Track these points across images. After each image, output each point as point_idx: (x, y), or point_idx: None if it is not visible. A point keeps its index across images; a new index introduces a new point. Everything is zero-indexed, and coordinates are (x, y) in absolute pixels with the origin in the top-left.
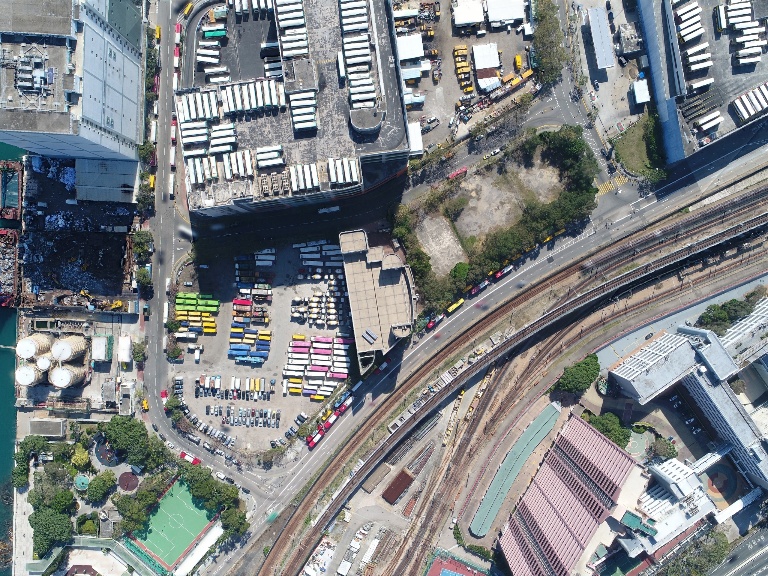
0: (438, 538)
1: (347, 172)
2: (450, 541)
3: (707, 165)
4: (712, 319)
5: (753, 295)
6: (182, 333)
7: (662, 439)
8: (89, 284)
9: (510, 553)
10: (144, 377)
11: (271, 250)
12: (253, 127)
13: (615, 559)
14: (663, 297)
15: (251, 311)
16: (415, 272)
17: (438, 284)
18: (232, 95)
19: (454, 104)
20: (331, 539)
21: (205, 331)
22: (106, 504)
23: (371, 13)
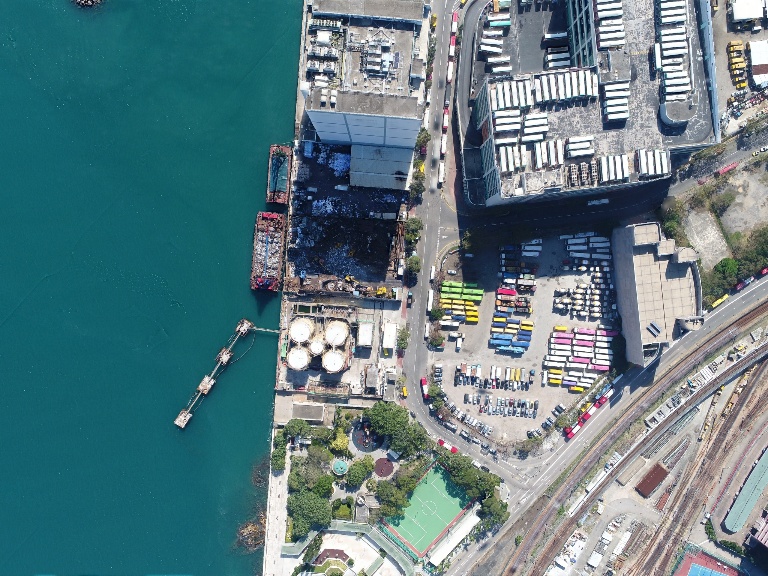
0: (689, 532)
1: (658, 164)
2: (701, 536)
3: None
4: None
5: None
6: (446, 321)
7: None
8: (353, 270)
9: None
10: (403, 364)
11: (539, 241)
12: (562, 117)
13: None
14: None
15: (514, 301)
16: None
17: (706, 279)
18: (547, 84)
19: (726, 99)
20: (583, 530)
21: (468, 320)
22: (360, 489)
23: (686, 6)
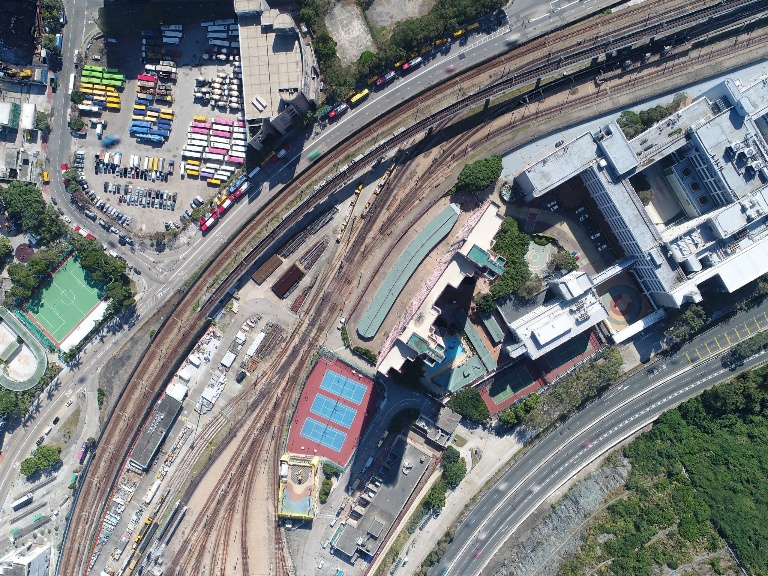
0: (325, 338)
1: None
2: (337, 342)
3: None
4: (625, 124)
5: (672, 103)
6: (86, 105)
7: (564, 251)
8: (2, 52)
9: None
10: (47, 150)
11: (178, 26)
12: None
13: (506, 376)
14: (577, 103)
15: (155, 89)
16: (320, 57)
17: (342, 70)
18: None
19: None
20: (218, 329)
21: (109, 106)
22: (2, 274)
23: None
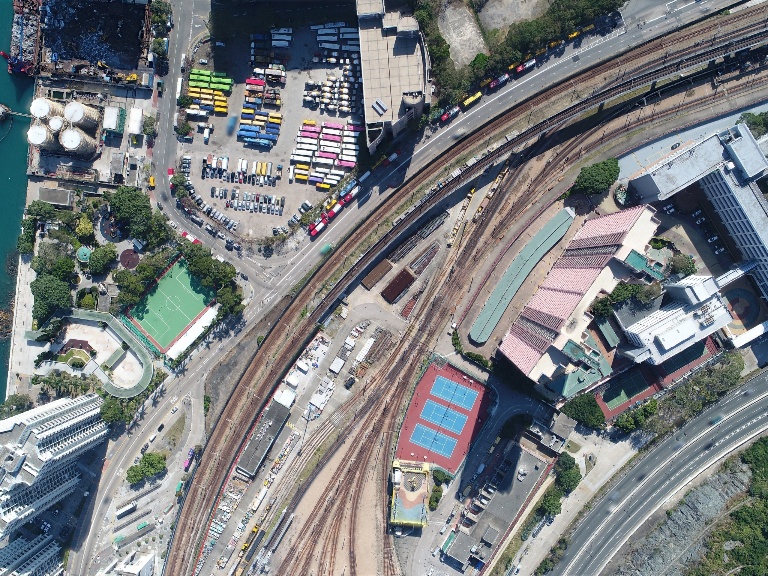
0: (435, 343)
1: None
2: (448, 347)
3: None
4: None
5: None
6: (193, 110)
7: (681, 255)
8: (107, 57)
9: (508, 347)
10: (153, 154)
11: (288, 30)
12: None
13: (620, 381)
14: (694, 105)
15: (263, 93)
16: (433, 60)
17: (456, 73)
18: None
19: None
20: (326, 334)
21: (216, 110)
22: (106, 280)
23: None
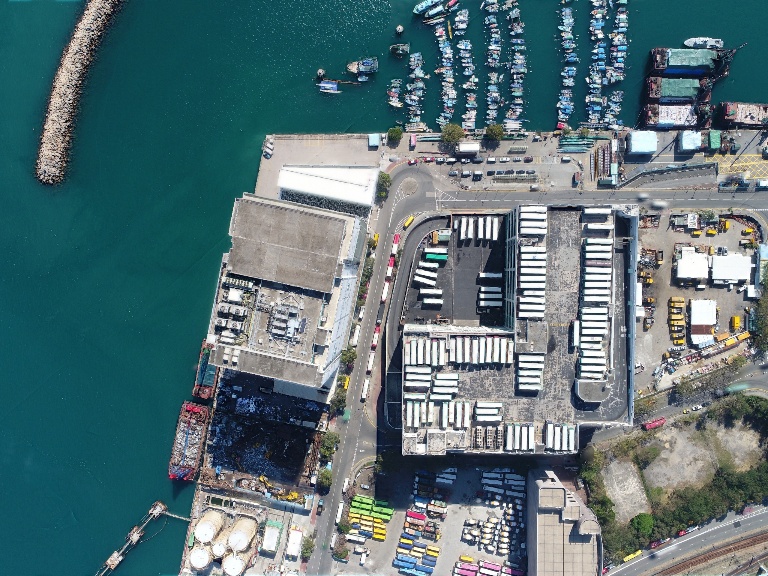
0: None
1: (565, 440)
2: None
3: None
4: None
5: None
6: (352, 536)
7: None
8: (268, 470)
9: None
10: (307, 569)
11: (454, 470)
12: (475, 377)
13: None
14: None
15: (423, 524)
16: None
17: (619, 534)
18: (461, 347)
19: (661, 353)
20: None
21: (375, 537)
22: None
23: (613, 285)
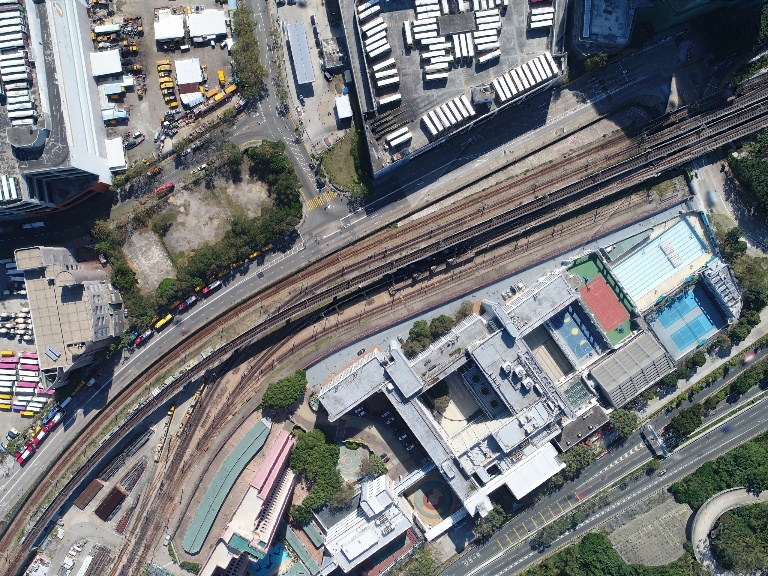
0: (153, 555)
1: (5, 189)
2: (165, 558)
3: (416, 180)
4: (417, 335)
5: None
6: None
7: (373, 456)
8: None
9: None
10: None
11: None
12: None
13: None
14: (374, 313)
15: None
16: None
17: (142, 300)
18: None
19: (160, 119)
20: (45, 556)
21: None
22: None
23: (30, 30)
